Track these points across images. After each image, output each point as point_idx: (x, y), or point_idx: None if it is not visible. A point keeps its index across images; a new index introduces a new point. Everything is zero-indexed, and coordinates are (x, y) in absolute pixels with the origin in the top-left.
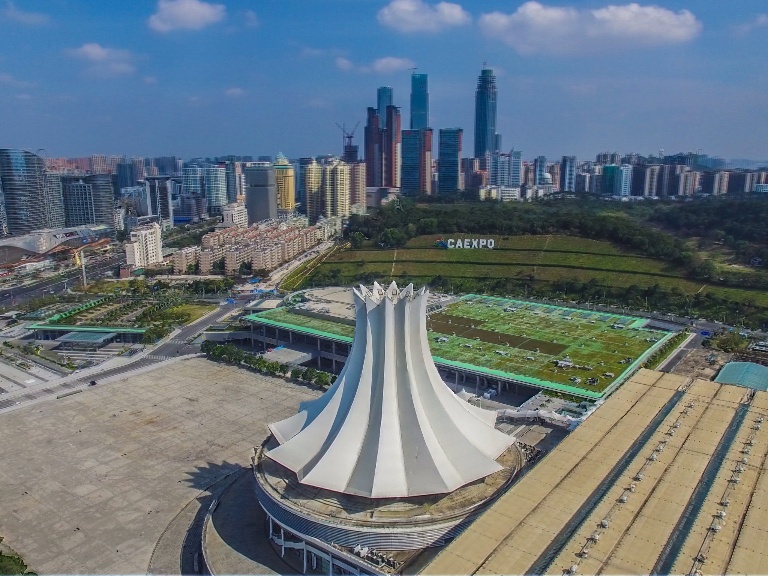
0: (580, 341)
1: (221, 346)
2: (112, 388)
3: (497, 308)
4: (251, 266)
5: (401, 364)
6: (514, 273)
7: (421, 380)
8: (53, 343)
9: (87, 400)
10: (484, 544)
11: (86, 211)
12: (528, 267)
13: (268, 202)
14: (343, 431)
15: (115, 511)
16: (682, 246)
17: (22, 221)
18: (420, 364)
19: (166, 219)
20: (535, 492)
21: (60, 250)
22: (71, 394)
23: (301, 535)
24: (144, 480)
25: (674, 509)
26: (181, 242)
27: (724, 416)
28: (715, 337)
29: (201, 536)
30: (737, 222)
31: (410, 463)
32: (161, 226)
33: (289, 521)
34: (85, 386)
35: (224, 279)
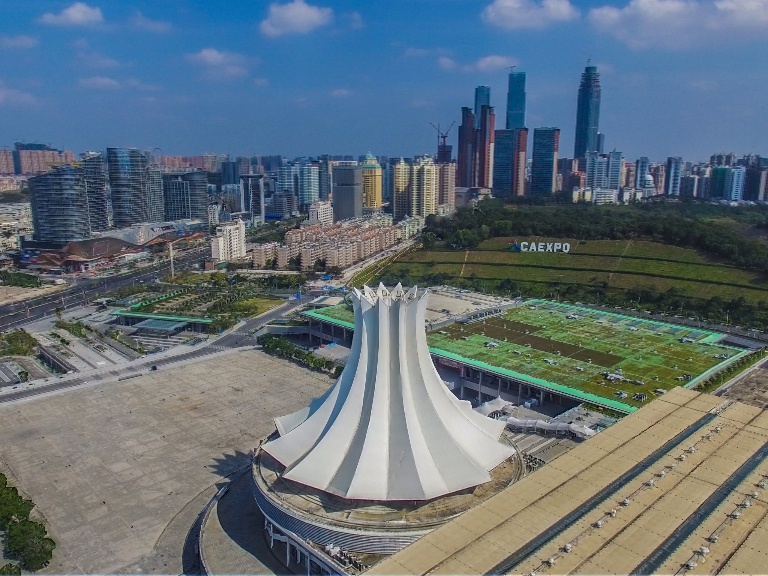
0: (639, 354)
1: (275, 339)
2: (169, 374)
3: (560, 315)
4: (325, 263)
5: (395, 366)
6: (588, 279)
7: (416, 384)
8: (132, 329)
9: (144, 384)
10: (432, 555)
11: (183, 206)
12: (603, 273)
13: (353, 201)
14: (333, 430)
15: (140, 489)
16: None
17: (126, 215)
18: (415, 368)
19: (258, 215)
20: (507, 507)
21: (156, 242)
22: (132, 377)
23: (281, 528)
24: (174, 462)
25: (652, 540)
26: (267, 238)
27: (752, 444)
28: None
29: (204, 520)
30: None
31: (394, 467)
32: (253, 222)
33: (272, 514)
34: (147, 370)
35: (297, 275)
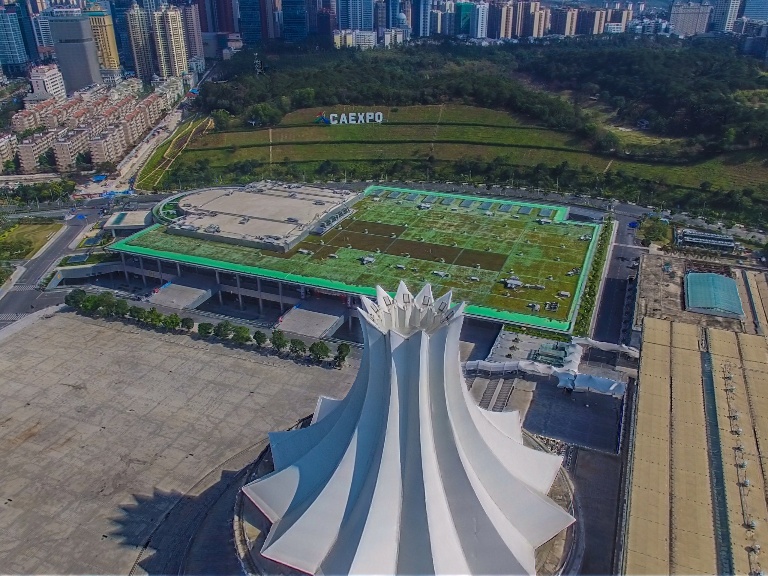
0: (516, 247)
1: (92, 296)
2: None
3: (409, 205)
4: (91, 159)
5: (438, 410)
6: (410, 152)
7: (460, 421)
8: None
9: None
10: None
11: None
12: (424, 145)
13: (87, 62)
14: (372, 513)
15: None
16: (581, 114)
17: None
18: (459, 401)
19: None
20: None
21: None
22: None
23: None
24: (52, 544)
25: None
26: None
27: None
28: (640, 226)
29: None
30: (610, 75)
31: (468, 542)
32: None
33: None
34: None
35: None
